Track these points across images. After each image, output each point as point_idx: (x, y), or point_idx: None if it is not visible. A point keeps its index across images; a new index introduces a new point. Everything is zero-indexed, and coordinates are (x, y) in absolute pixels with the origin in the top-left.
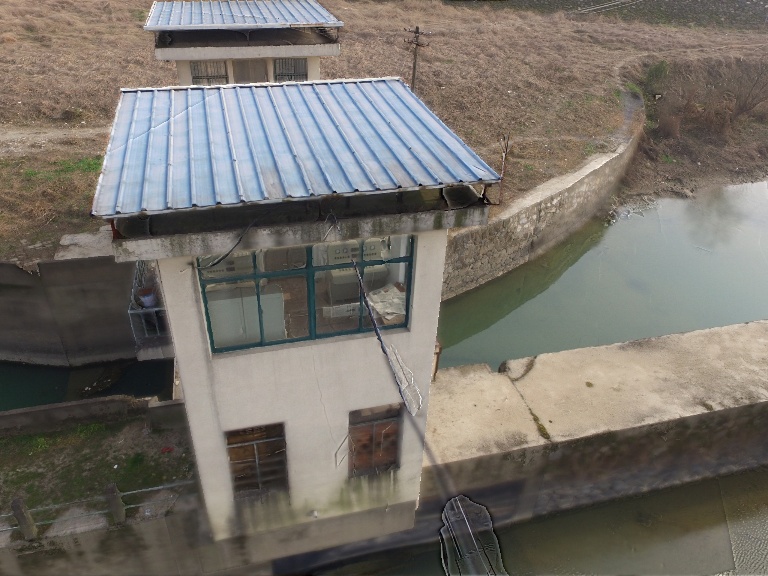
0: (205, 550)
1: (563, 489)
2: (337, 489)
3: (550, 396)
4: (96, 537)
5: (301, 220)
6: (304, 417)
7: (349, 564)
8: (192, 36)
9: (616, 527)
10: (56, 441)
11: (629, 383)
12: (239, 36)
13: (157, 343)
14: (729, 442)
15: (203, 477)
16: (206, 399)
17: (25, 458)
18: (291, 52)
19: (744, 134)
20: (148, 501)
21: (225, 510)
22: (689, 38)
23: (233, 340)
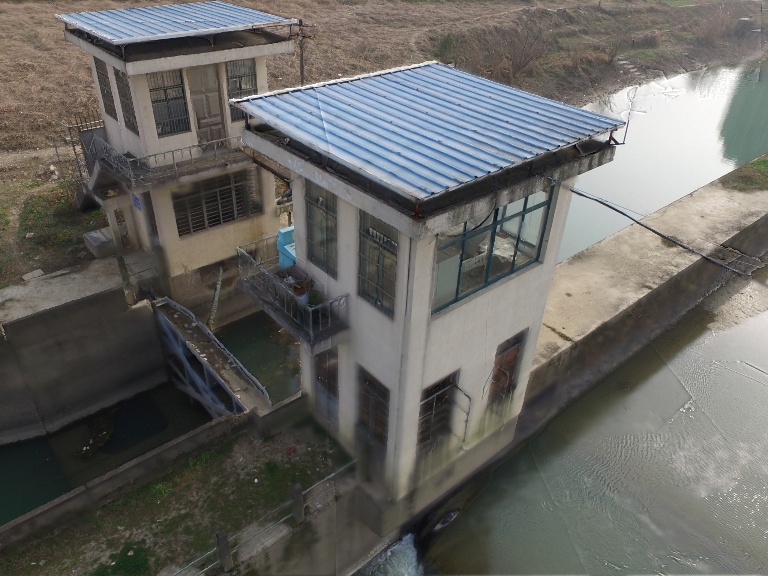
0: (387, 514)
1: (575, 381)
2: (478, 421)
3: (550, 311)
4: (283, 545)
5: (506, 181)
6: (473, 359)
7: (451, 498)
8: (146, 47)
9: (609, 399)
10: (176, 482)
11: (592, 286)
12: (191, 42)
13: (325, 335)
14: (657, 312)
15: (402, 440)
16: (419, 362)
17: (156, 508)
18: (253, 53)
19: (524, 88)
20: (311, 496)
21: (409, 468)
22: (449, 12)
23: (433, 303)
